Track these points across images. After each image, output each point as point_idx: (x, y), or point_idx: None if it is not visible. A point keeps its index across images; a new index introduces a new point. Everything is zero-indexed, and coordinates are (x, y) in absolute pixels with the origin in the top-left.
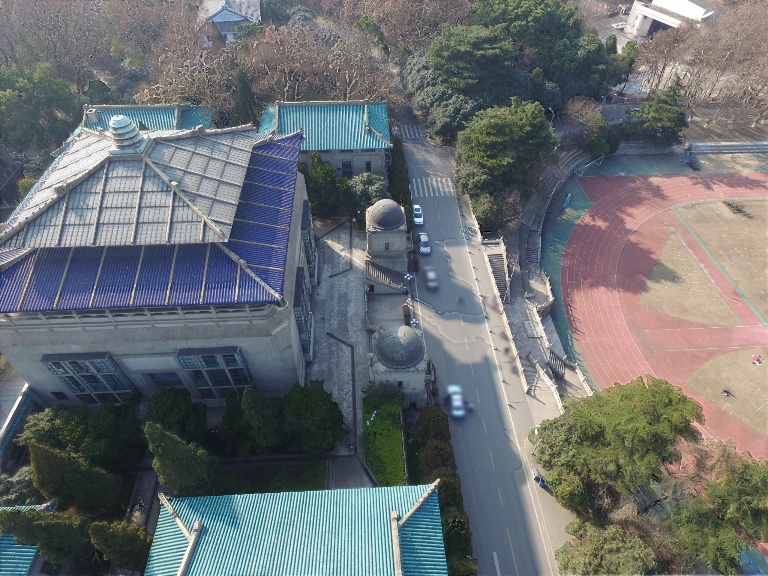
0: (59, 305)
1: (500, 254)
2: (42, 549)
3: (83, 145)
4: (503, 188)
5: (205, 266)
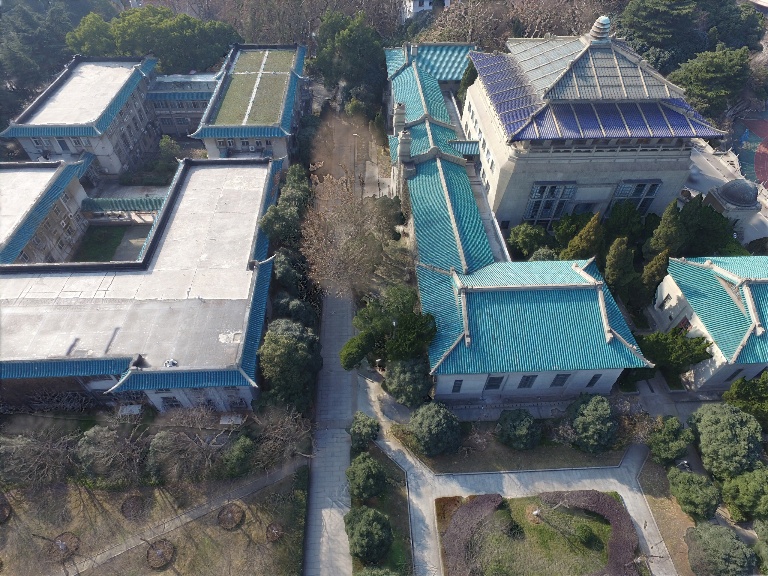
0: (585, 135)
1: (731, 161)
2: (616, 274)
3: (527, 47)
4: (716, 116)
5: (664, 116)
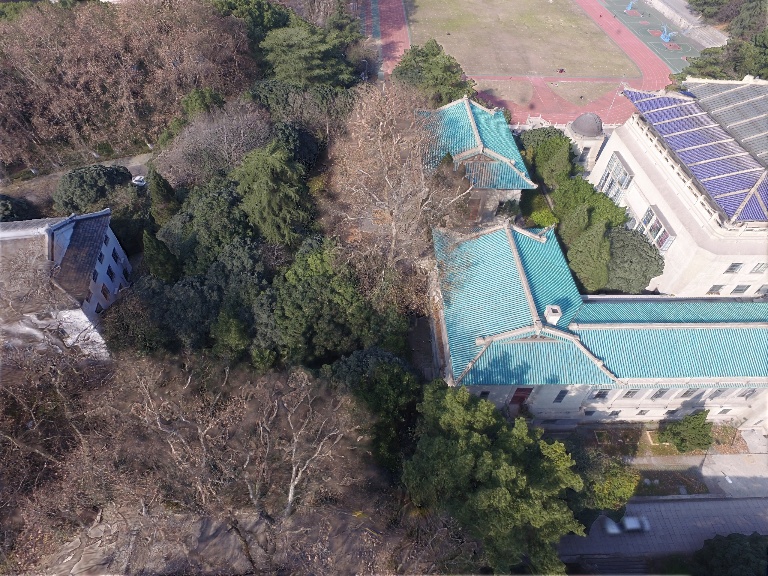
0: None
1: (540, 123)
2: None
3: None
4: None
5: None
